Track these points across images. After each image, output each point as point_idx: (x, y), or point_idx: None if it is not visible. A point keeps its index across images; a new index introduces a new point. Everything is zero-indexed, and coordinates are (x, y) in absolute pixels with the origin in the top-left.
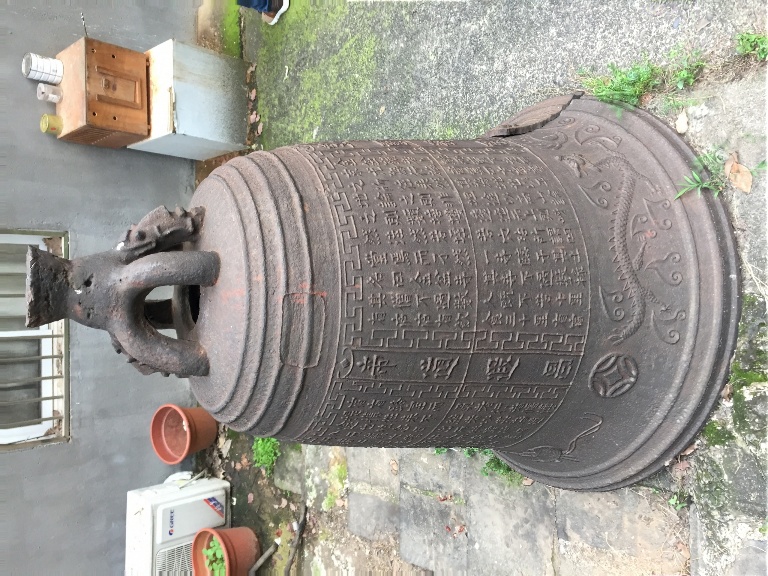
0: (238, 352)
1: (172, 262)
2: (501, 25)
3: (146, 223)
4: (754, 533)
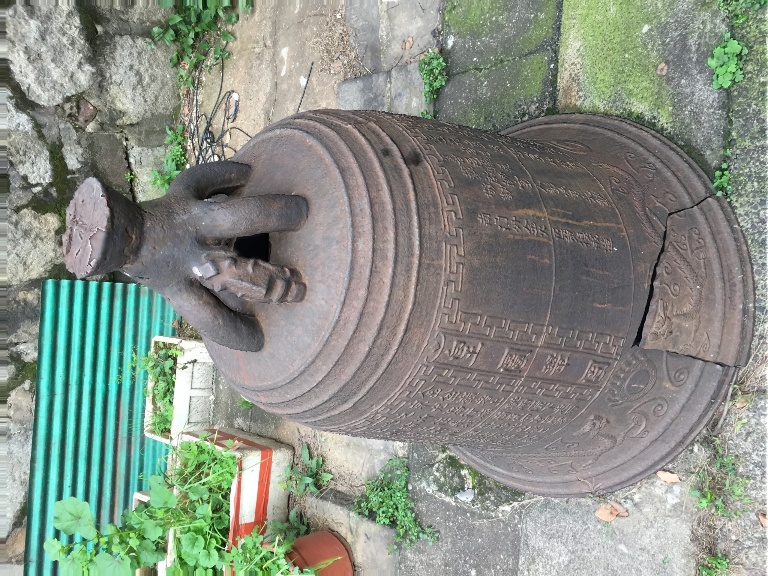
0: (216, 359)
1: (217, 340)
2: None
3: (236, 285)
4: (400, 449)
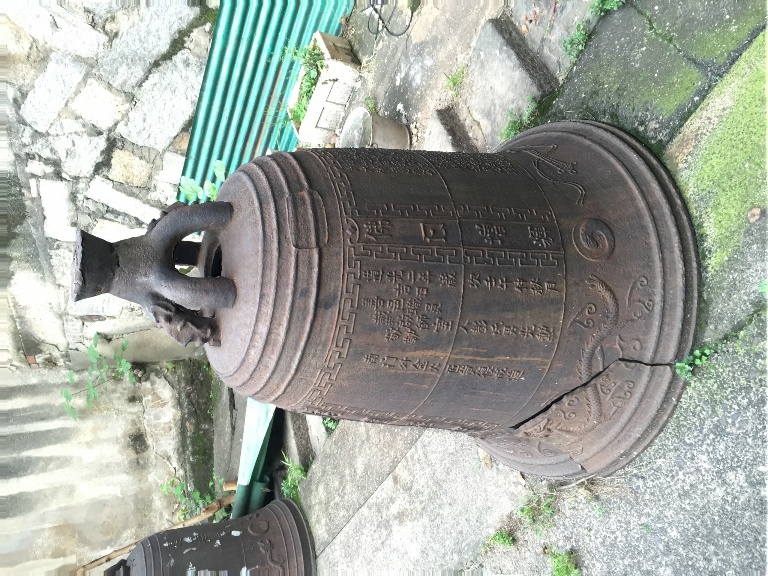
0: None
1: None
2: (763, 534)
3: None
4: None
